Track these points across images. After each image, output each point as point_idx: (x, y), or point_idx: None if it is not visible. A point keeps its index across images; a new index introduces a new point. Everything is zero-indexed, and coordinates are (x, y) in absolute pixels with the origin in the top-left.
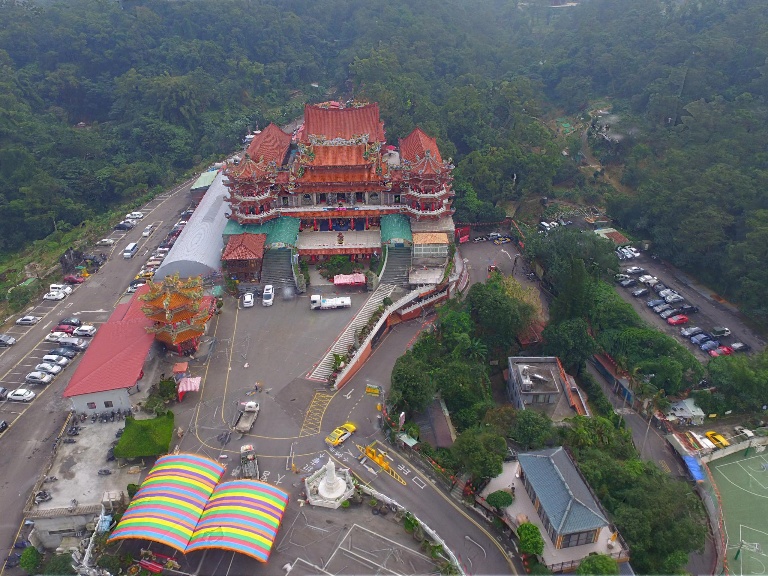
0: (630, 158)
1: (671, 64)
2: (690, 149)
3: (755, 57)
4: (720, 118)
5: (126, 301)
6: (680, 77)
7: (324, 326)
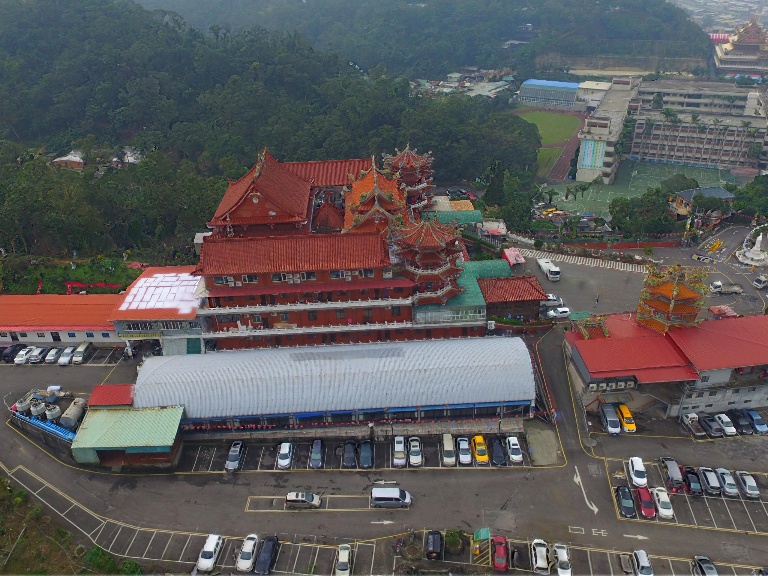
0: (250, 148)
1: (79, 85)
2: (272, 122)
3: (163, 56)
4: (246, 98)
5: (550, 454)
6: (154, 84)
7: (582, 274)
